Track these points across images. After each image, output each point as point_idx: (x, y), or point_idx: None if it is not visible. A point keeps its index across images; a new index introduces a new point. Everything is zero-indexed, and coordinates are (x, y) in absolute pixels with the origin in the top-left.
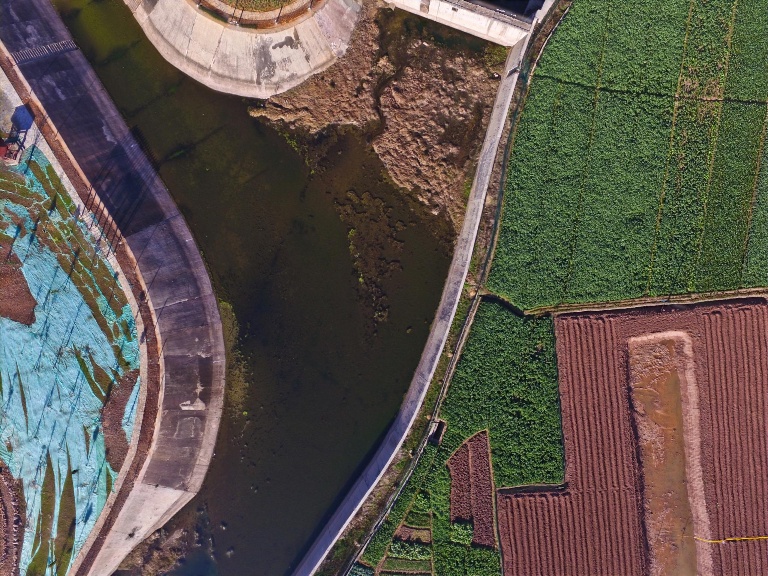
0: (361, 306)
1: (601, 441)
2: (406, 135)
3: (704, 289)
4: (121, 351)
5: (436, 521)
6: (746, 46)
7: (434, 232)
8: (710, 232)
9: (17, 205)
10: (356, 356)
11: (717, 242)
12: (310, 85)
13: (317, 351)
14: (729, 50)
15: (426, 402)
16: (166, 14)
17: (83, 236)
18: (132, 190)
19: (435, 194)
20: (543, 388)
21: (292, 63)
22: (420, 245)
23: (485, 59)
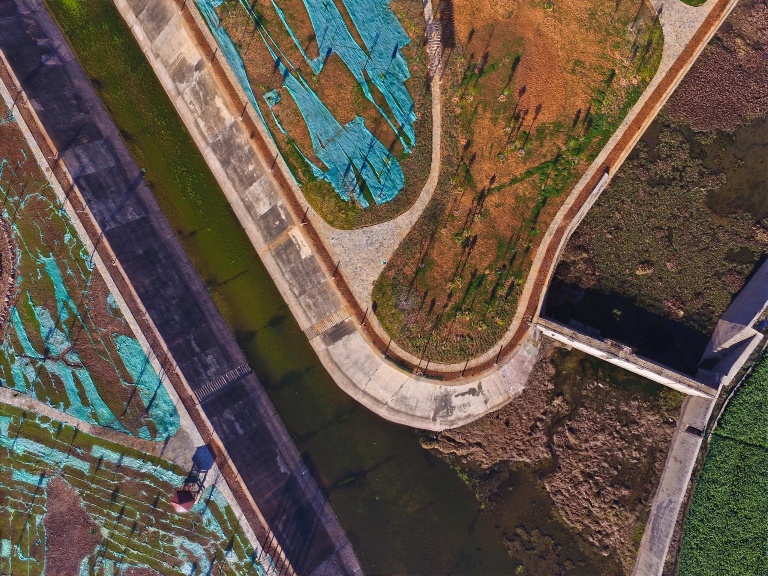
0: None
1: None
2: (579, 475)
3: None
4: None
5: None
6: None
7: (603, 573)
8: None
9: (194, 543)
10: None
11: None
12: (485, 423)
13: None
14: None
15: None
16: (348, 353)
17: None
18: (305, 525)
19: (606, 535)
20: None
21: (471, 406)
22: None
23: (660, 403)
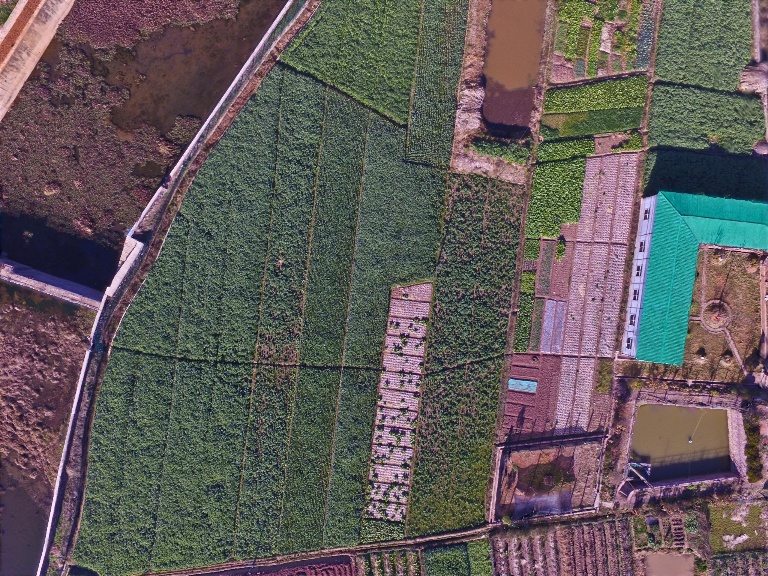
0: None
1: None
2: (0, 400)
3: (288, 551)
4: None
5: None
6: (317, 314)
7: (33, 496)
8: (291, 496)
9: None
10: None
11: (298, 505)
12: None
13: None
14: (303, 317)
15: None
16: None
17: None
18: None
19: (32, 458)
20: None
21: None
22: (21, 508)
23: (78, 322)
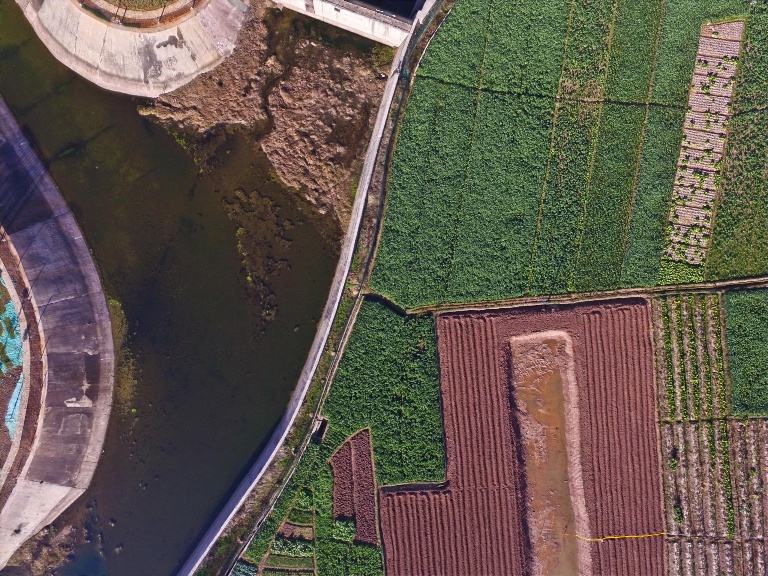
0: (249, 304)
1: (481, 440)
2: (294, 134)
3: (584, 289)
4: (4, 348)
5: (318, 518)
6: (625, 48)
7: (321, 231)
8: (590, 232)
9: None
10: (244, 354)
11: (596, 242)
12: (198, 84)
13: (206, 349)
14: (609, 52)
15: (309, 400)
16: (52, 12)
17: None
18: (19, 188)
19: (322, 193)
20: (424, 387)
21: (178, 62)
22: (308, 244)
23: (372, 59)
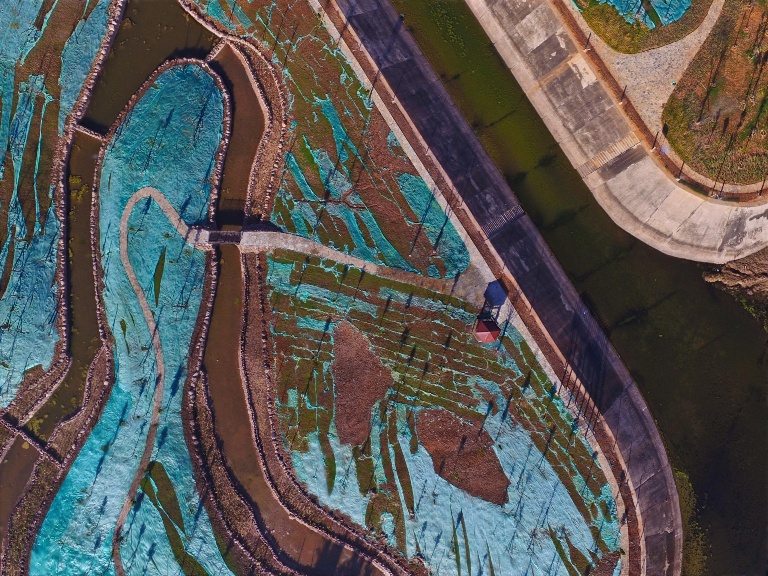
0: None
1: None
2: None
3: None
4: (600, 533)
5: None
6: None
7: None
8: None
9: (489, 382)
10: None
11: None
12: None
13: None
14: None
15: None
16: (632, 184)
17: (559, 414)
18: (596, 362)
19: None
20: None
21: (762, 232)
22: None
23: None
